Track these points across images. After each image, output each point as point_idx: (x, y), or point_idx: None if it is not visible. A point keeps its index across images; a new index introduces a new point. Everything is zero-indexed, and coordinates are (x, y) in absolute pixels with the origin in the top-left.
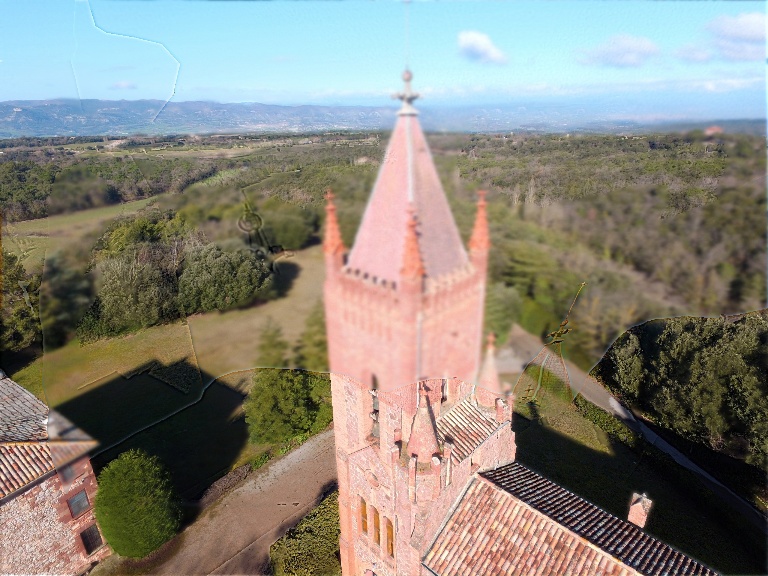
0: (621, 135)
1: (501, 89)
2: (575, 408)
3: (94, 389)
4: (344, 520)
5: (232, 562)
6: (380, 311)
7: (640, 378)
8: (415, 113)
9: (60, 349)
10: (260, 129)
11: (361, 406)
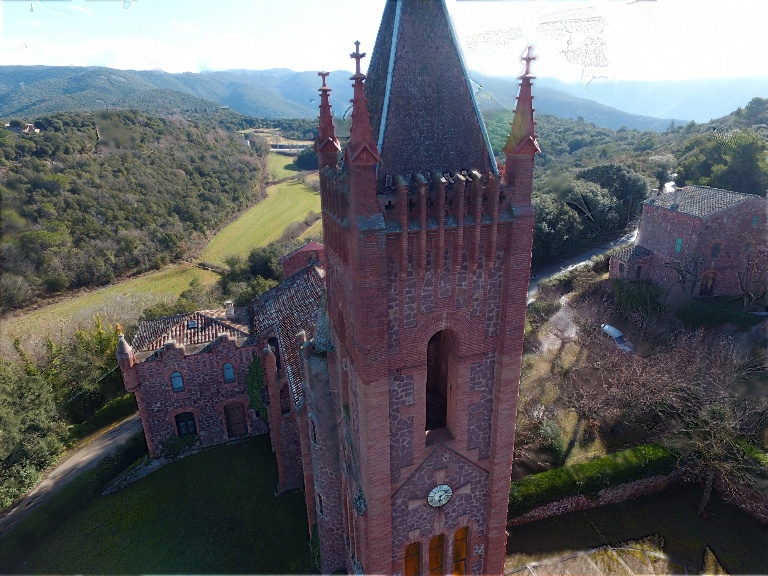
0: (488, 31)
1: (517, 18)
2: None
3: (605, 78)
4: None
5: None
6: None
7: None
8: (532, 20)
9: (613, 68)
10: (569, 17)
11: None
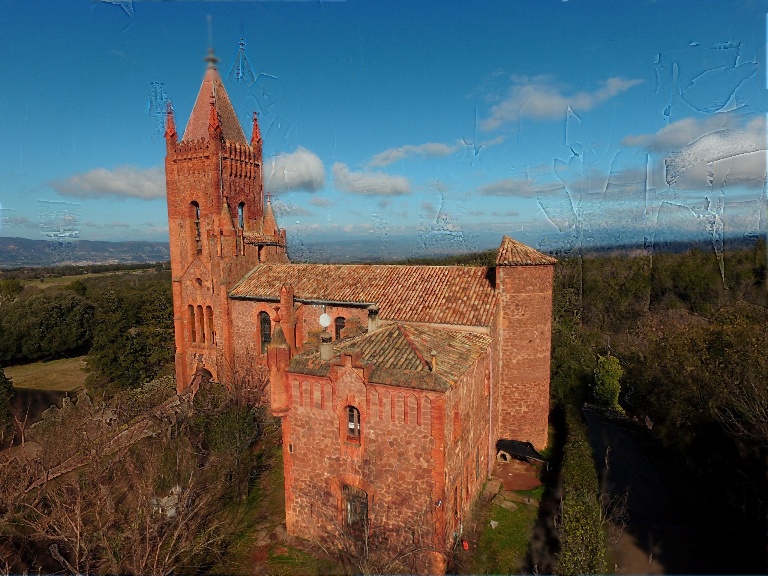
0: None
1: None
2: None
3: None
4: (178, 335)
5: None
6: (186, 24)
7: None
8: None
9: None
10: None
11: (189, 230)
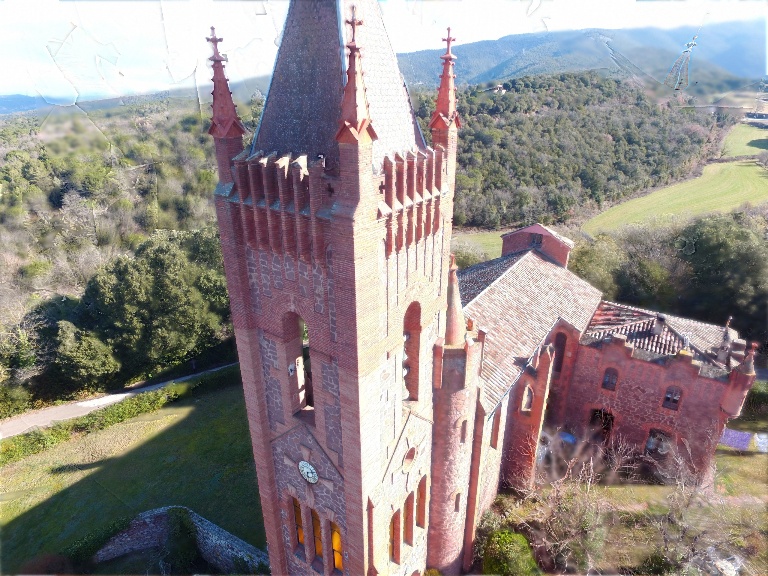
0: None
1: None
2: (80, 435)
3: None
4: None
5: None
6: None
7: (109, 351)
8: None
9: None
10: None
11: (401, 373)
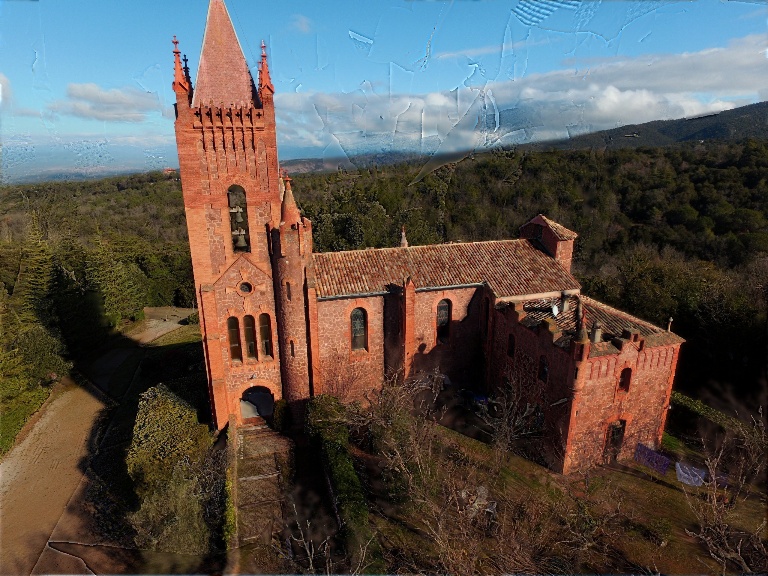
0: None
1: None
2: None
3: None
4: (216, 357)
5: (44, 561)
6: None
7: None
8: None
9: None
10: None
11: (228, 223)
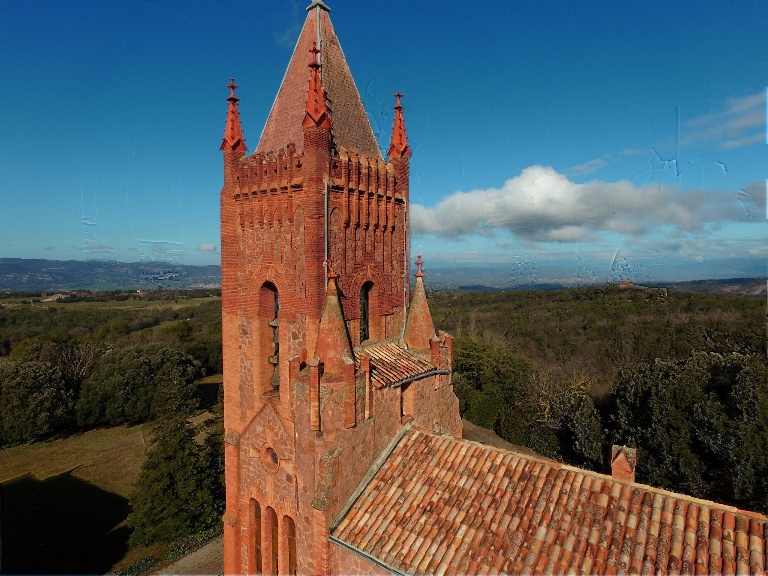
0: None
1: None
2: None
3: None
4: (230, 555)
5: None
6: None
7: (602, 440)
8: None
9: None
10: None
11: (258, 343)
